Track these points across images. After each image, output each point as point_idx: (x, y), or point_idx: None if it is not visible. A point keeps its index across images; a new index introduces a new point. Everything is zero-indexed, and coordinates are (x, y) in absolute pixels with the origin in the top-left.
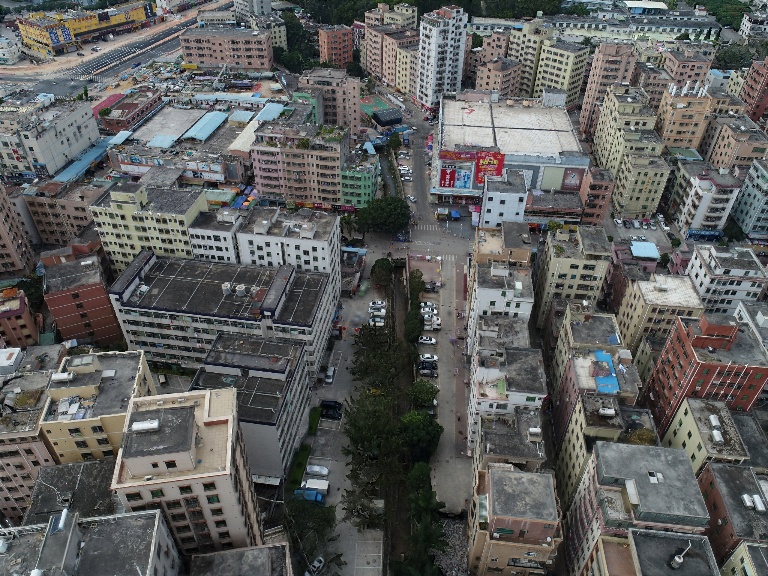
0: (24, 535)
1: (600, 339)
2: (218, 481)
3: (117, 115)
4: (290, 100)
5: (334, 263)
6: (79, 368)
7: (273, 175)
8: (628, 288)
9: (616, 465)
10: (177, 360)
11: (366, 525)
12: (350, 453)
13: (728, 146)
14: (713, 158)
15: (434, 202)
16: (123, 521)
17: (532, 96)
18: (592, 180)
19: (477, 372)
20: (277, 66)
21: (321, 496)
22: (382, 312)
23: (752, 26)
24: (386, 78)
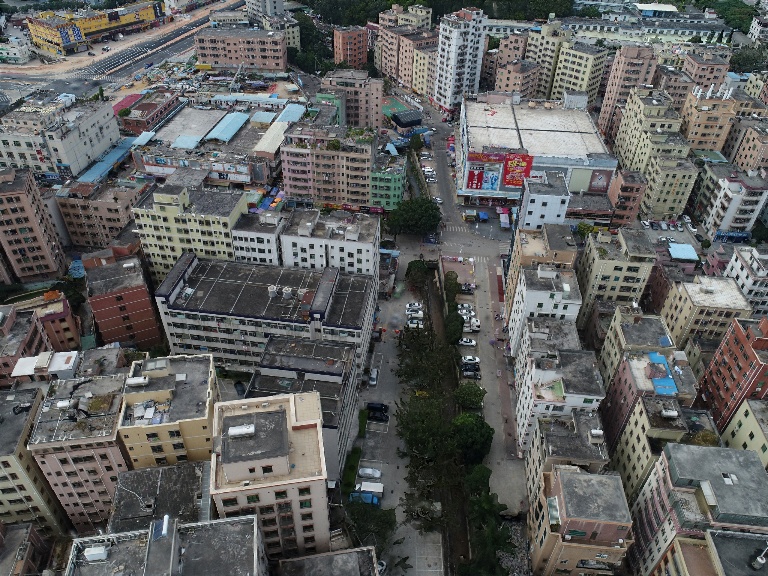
0: (122, 542)
1: (651, 341)
2: (313, 486)
3: (137, 116)
4: (307, 101)
5: (375, 265)
6: (153, 372)
7: (302, 176)
8: (672, 290)
9: (689, 467)
10: (221, 363)
11: (424, 528)
12: (405, 456)
13: (753, 148)
14: (737, 160)
15: (460, 204)
16: (220, 527)
17: (549, 98)
18: (624, 182)
19: (532, 374)
20: (290, 67)
21: (377, 499)
22: (420, 314)
23: (762, 29)
24: (402, 79)
